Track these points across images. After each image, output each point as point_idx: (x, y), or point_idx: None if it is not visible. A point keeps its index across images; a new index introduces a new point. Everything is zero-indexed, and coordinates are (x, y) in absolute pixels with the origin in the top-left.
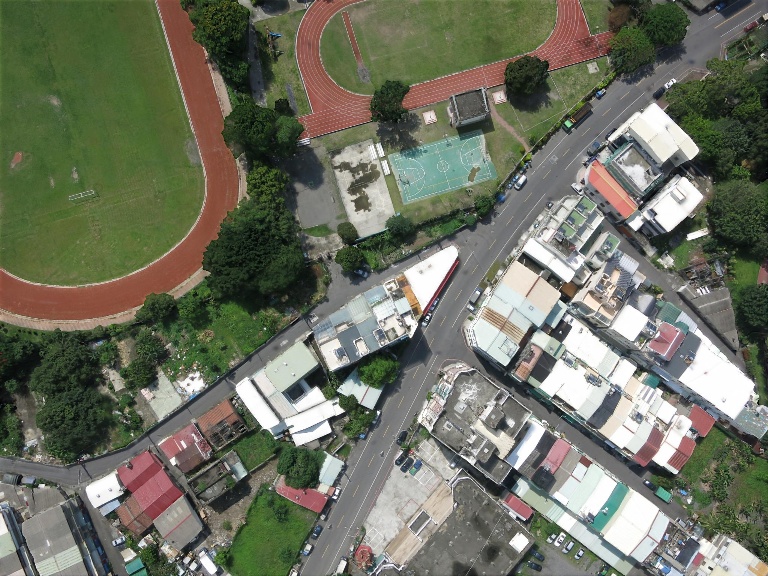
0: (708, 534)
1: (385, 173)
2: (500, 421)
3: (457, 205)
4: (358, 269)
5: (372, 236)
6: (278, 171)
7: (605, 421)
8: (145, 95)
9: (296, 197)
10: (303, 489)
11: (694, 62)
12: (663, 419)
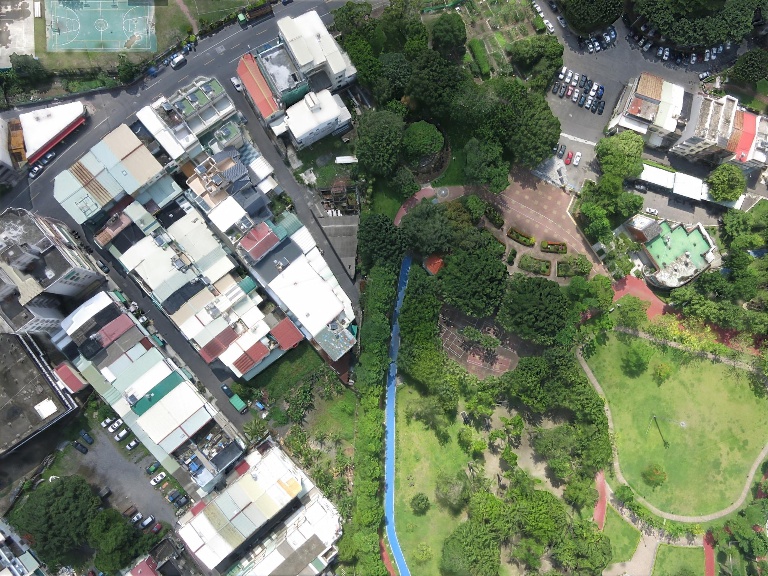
0: (262, 447)
1: (35, 15)
2: (39, 269)
3: (105, 67)
4: None
5: None
6: None
7: (178, 307)
8: None
9: None
10: None
11: None
12: (246, 322)
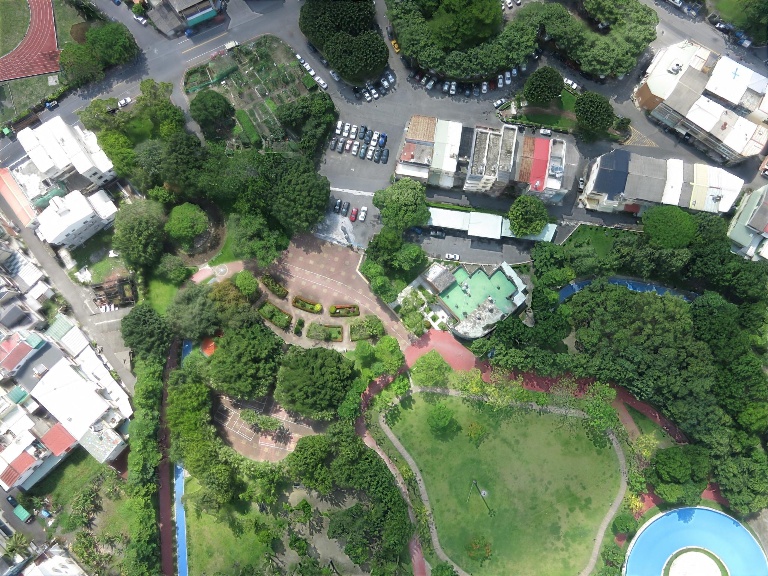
0: (39, 559)
1: None
2: None
3: None
4: None
5: None
6: None
7: None
8: None
9: None
10: None
11: None
12: (15, 433)
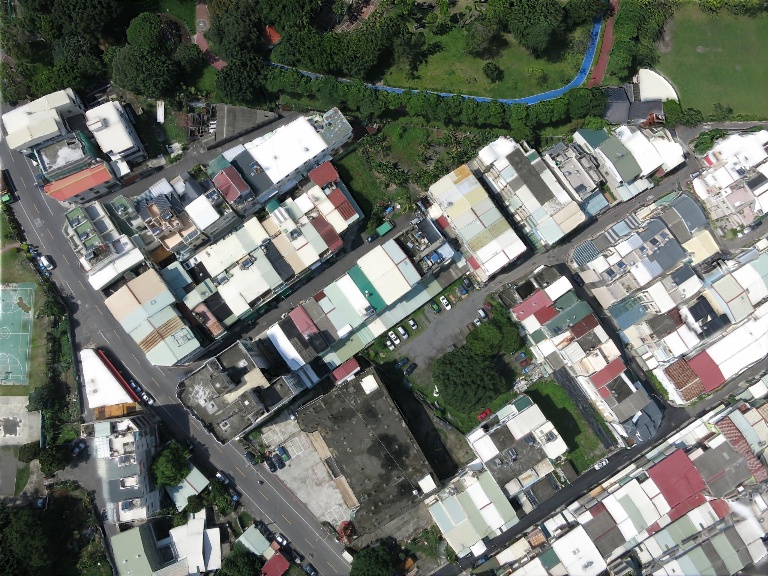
0: (425, 204)
1: None
2: (238, 373)
3: None
4: (72, 452)
5: (42, 429)
6: None
7: (288, 265)
8: None
9: None
10: (260, 575)
11: None
12: (309, 209)
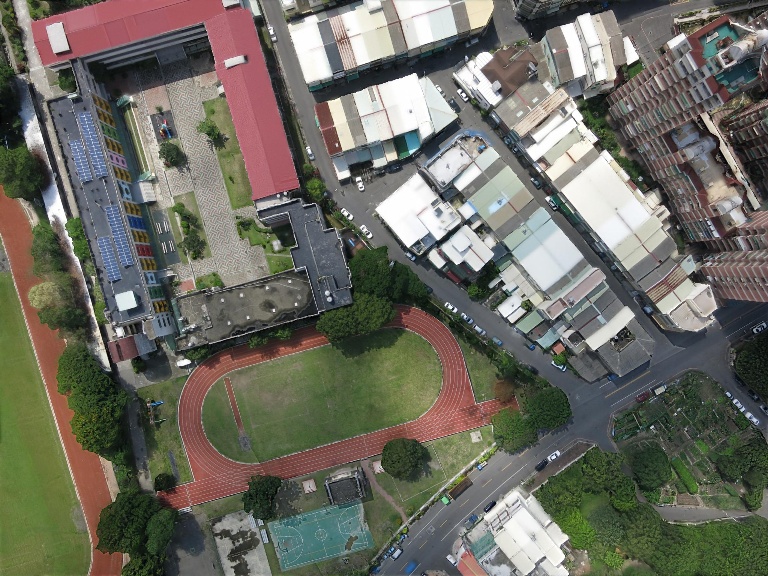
0: None
1: (264, 541)
2: None
3: (333, 573)
4: None
5: None
6: (152, 563)
7: None
8: (32, 462)
9: (178, 563)
10: None
11: (581, 433)
12: None
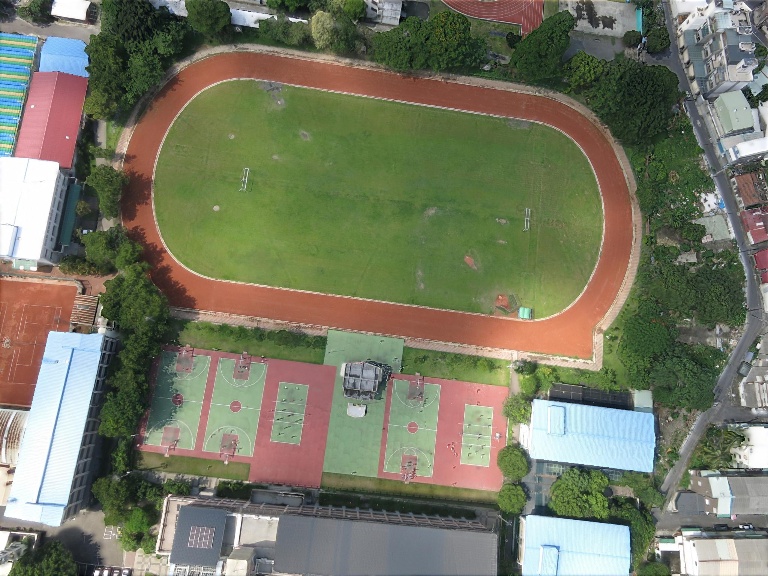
0: None
1: None
2: None
3: None
4: None
5: (643, 22)
6: None
7: None
8: (455, 140)
9: None
10: None
11: None
12: None
